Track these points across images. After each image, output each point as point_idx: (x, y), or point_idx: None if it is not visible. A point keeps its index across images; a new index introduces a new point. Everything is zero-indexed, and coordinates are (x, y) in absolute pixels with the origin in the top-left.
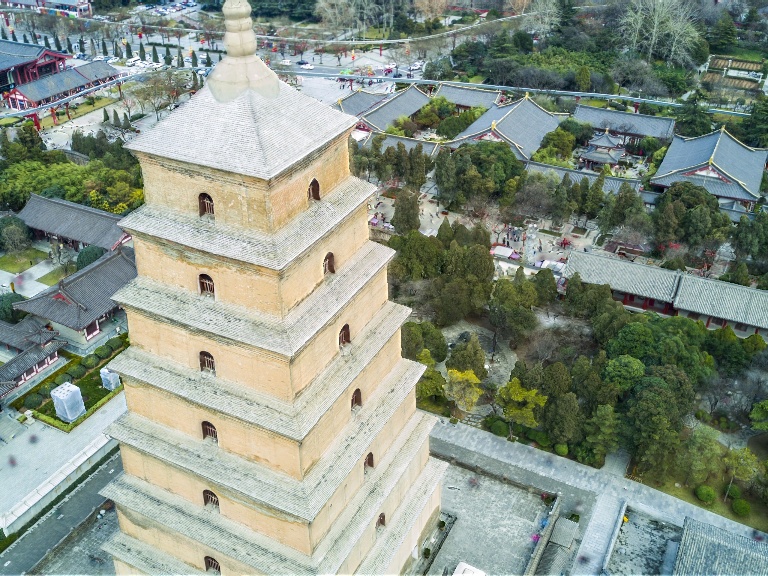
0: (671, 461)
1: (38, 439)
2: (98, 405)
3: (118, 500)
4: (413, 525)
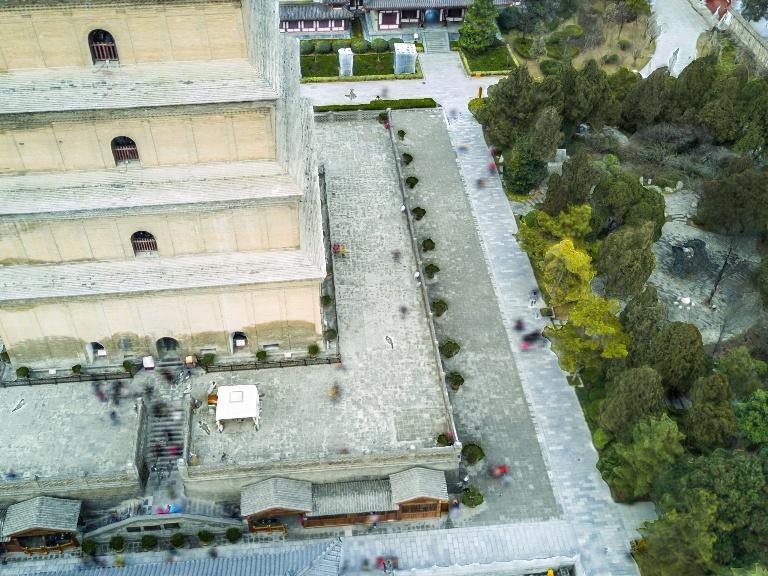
0: None
1: None
2: (315, 79)
3: None
4: (226, 297)
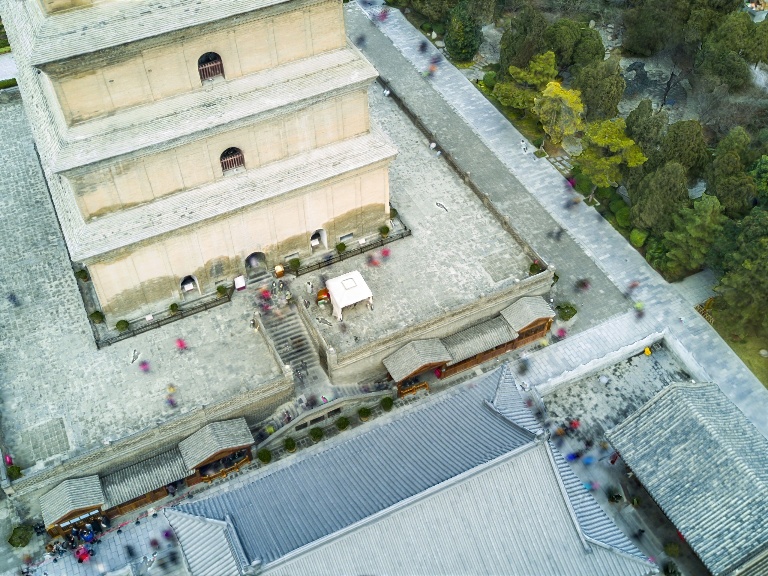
0: (763, 312)
1: None
2: None
3: (2, 16)
4: (309, 197)
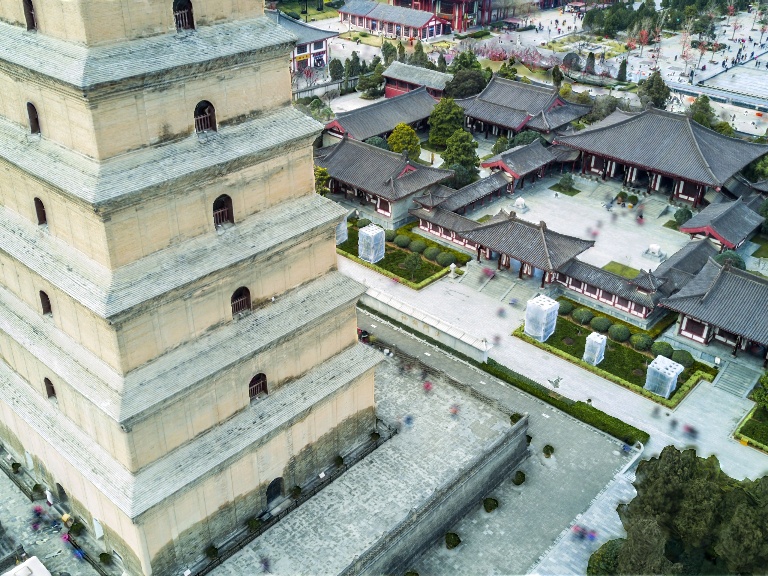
0: None
1: (505, 317)
2: (555, 350)
3: None
4: None
